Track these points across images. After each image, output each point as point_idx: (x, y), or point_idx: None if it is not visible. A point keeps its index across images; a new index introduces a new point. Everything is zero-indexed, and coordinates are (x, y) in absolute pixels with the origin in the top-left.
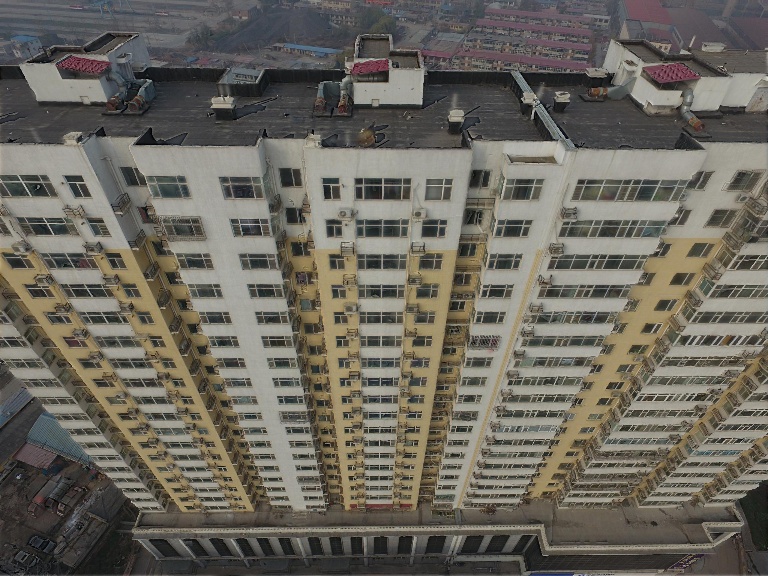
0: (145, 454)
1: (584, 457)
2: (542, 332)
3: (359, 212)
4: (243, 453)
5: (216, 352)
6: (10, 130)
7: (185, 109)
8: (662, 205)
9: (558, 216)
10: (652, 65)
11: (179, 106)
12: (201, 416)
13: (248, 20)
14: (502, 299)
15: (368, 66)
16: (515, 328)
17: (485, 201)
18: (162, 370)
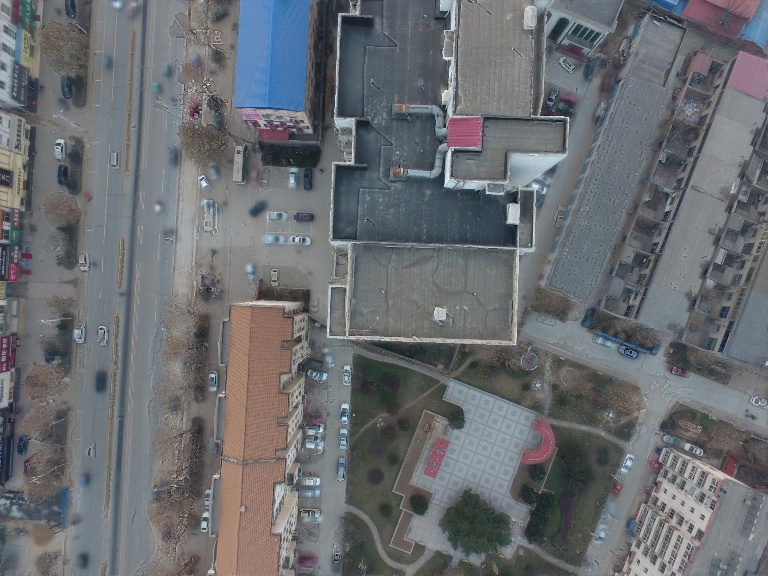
0: None
1: None
2: None
3: None
4: None
5: None
6: None
7: None
8: None
9: None
10: None
11: None
12: None
13: None
14: None
15: None
16: None
17: None
18: None
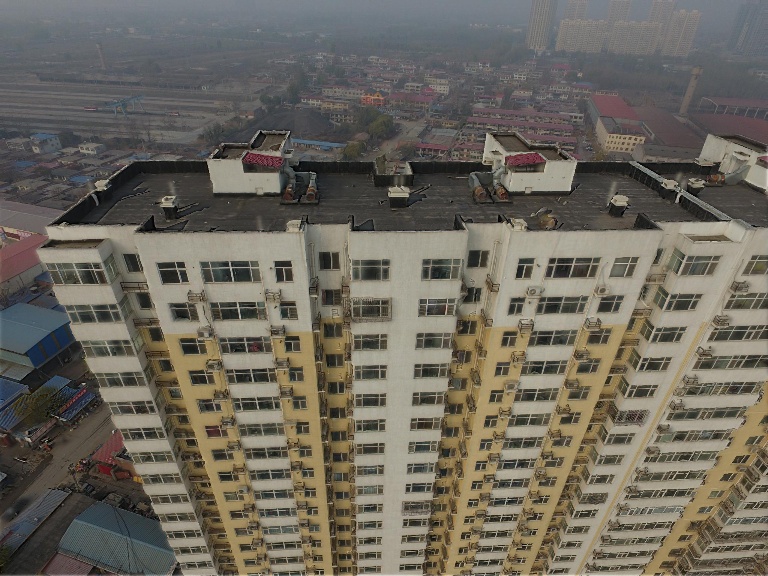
0: (241, 558)
1: (697, 541)
2: (689, 405)
3: (545, 290)
4: (341, 553)
5: (359, 437)
6: (203, 219)
7: (353, 198)
8: None
9: (728, 290)
10: (766, 155)
11: (345, 195)
12: (318, 510)
13: (254, 119)
14: (658, 372)
15: (522, 158)
16: (664, 401)
17: (656, 277)
18: (296, 459)
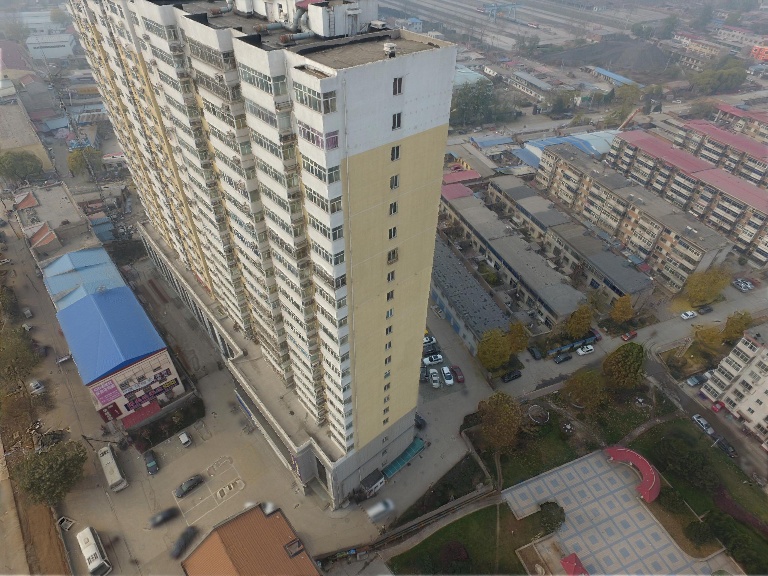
0: None
1: None
2: None
3: (114, 20)
4: None
5: None
6: None
7: None
8: (164, 42)
9: None
10: None
11: None
12: None
13: (594, 44)
14: None
15: None
16: None
17: None
18: None
